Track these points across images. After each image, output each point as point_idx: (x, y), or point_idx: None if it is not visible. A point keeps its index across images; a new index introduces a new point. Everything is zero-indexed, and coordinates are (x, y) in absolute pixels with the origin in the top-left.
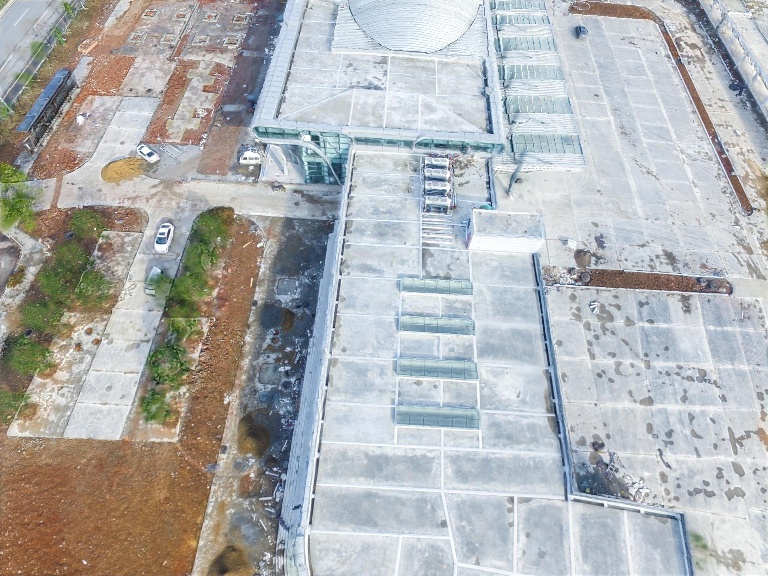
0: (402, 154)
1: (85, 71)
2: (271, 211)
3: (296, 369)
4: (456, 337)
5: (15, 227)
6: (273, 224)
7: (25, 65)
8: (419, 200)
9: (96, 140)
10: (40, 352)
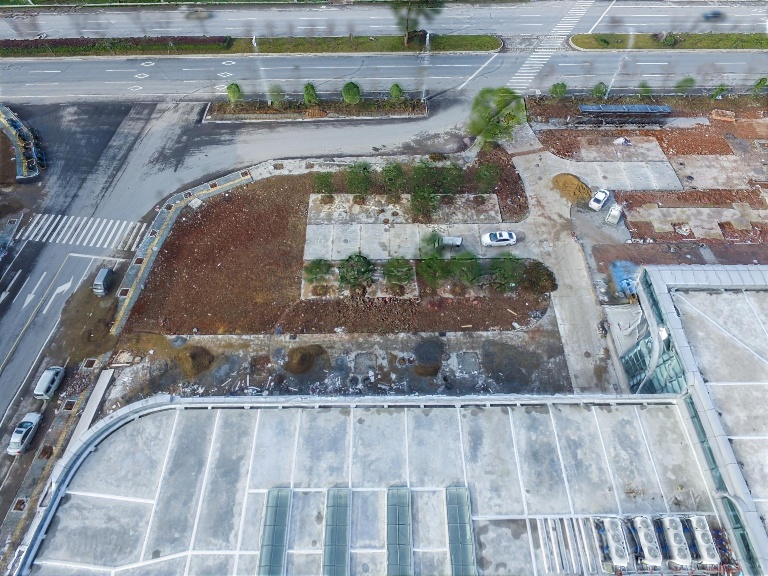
0: (703, 478)
1: (687, 125)
2: (566, 328)
3: (372, 388)
4: (385, 575)
5: (485, 141)
6: (549, 333)
7: (668, 86)
8: (617, 512)
9: (600, 159)
10: (374, 191)
